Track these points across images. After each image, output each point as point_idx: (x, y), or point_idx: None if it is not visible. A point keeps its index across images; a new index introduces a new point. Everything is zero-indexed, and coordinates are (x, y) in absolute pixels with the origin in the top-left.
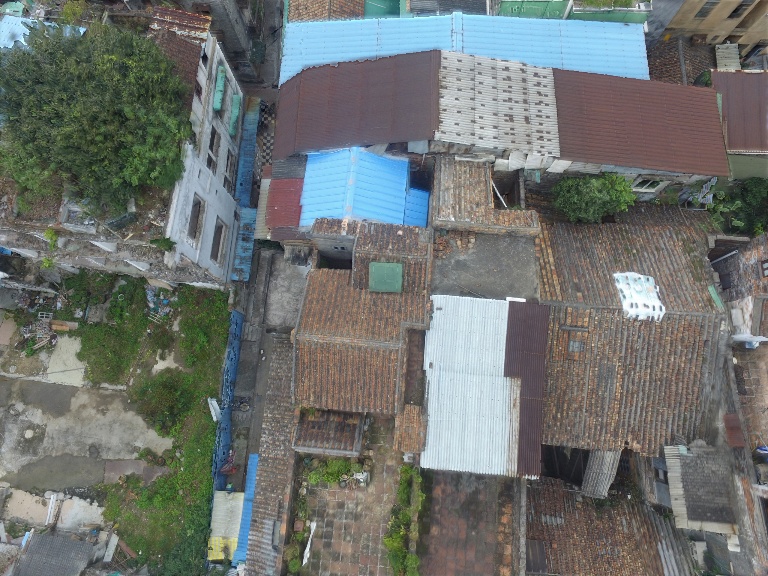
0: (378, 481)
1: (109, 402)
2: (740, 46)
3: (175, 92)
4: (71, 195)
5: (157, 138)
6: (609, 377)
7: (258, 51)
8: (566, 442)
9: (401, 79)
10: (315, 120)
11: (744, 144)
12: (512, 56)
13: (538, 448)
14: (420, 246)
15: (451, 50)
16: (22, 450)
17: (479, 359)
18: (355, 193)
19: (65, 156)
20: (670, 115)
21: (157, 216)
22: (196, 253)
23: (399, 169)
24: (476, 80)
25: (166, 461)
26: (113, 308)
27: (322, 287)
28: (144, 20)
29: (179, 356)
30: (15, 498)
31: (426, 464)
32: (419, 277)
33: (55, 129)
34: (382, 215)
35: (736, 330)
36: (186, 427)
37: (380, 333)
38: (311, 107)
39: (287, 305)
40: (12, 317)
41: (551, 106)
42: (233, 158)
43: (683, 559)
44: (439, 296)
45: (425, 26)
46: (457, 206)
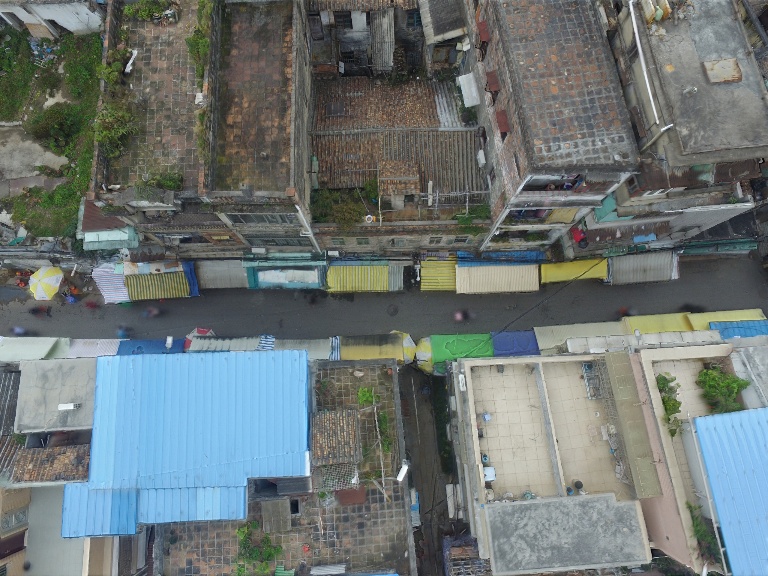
0: (185, 20)
1: (8, 136)
2: None
3: None
4: None
5: None
6: None
7: None
8: (345, 6)
9: None
10: None
11: None
12: None
13: None
14: None
15: None
16: None
17: None
18: None
19: None
20: None
21: None
22: None
23: None
24: None
25: (63, 173)
26: (1, 60)
27: None
28: None
29: (66, 93)
30: None
31: None
32: None
33: None
34: None
35: None
36: (78, 145)
37: None
38: None
39: None
40: None
41: None
42: None
43: (452, 101)
44: None
45: None
46: None
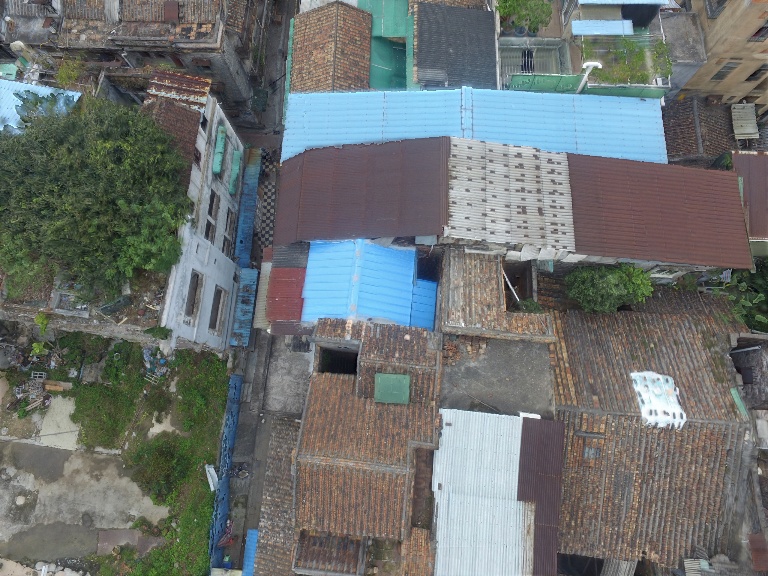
0: None
1: (103, 467)
2: (757, 105)
3: (172, 169)
4: (63, 278)
5: (153, 227)
6: (626, 485)
7: (259, 99)
8: (580, 551)
9: (409, 167)
10: (318, 207)
11: (767, 231)
12: (524, 134)
13: None
14: (428, 354)
15: (460, 128)
16: (13, 518)
17: (491, 480)
18: (360, 290)
19: (56, 248)
20: (690, 202)
21: (153, 299)
22: (193, 331)
23: (406, 259)
24: (487, 168)
25: (161, 531)
26: (108, 367)
27: (325, 396)
28: (142, 80)
29: (176, 419)
30: (5, 569)
31: None
32: (427, 387)
33: (46, 220)
34: (388, 312)
35: (762, 442)
36: (182, 495)
37: (386, 454)
38: (314, 192)
39: (288, 389)
40: (4, 376)
41: (566, 195)
42: (233, 215)
43: None
44: (448, 410)
45: (433, 101)
46: (467, 308)
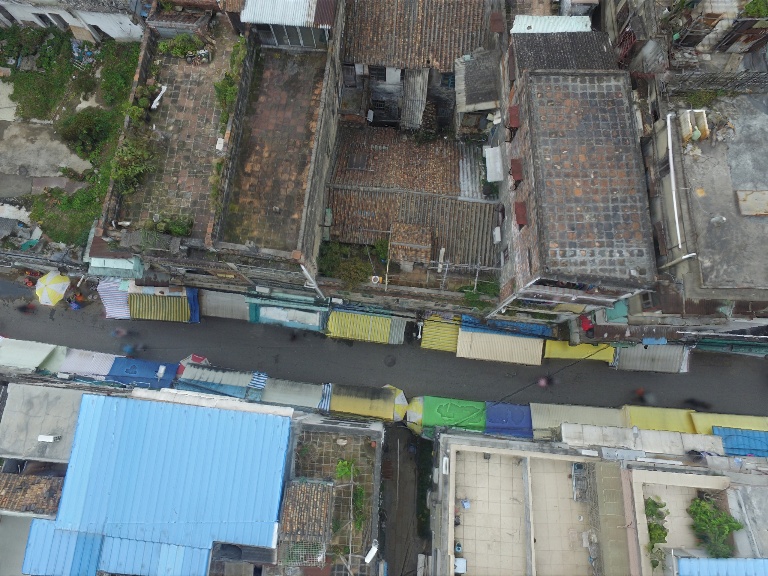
0: (218, 61)
1: (37, 133)
2: None
3: None
4: None
5: None
6: (413, 2)
7: None
8: (381, 62)
9: None
10: None
11: None
12: None
13: (331, 6)
14: None
15: None
16: None
17: None
18: None
19: None
20: None
21: None
22: None
23: None
24: None
25: (86, 177)
26: (42, 57)
27: None
28: None
29: (100, 97)
30: None
31: (244, 18)
32: None
33: None
34: None
35: None
36: (104, 152)
37: None
38: None
39: None
40: None
41: None
42: None
43: (477, 167)
44: None
45: None
46: None
